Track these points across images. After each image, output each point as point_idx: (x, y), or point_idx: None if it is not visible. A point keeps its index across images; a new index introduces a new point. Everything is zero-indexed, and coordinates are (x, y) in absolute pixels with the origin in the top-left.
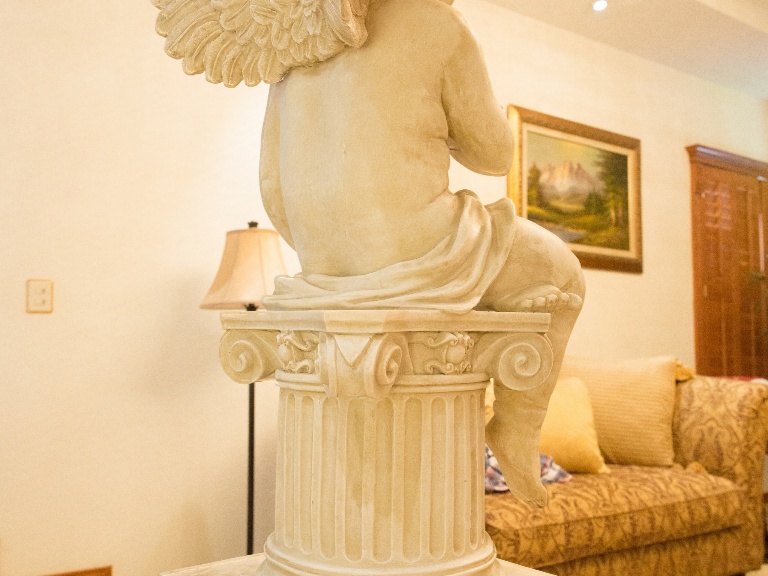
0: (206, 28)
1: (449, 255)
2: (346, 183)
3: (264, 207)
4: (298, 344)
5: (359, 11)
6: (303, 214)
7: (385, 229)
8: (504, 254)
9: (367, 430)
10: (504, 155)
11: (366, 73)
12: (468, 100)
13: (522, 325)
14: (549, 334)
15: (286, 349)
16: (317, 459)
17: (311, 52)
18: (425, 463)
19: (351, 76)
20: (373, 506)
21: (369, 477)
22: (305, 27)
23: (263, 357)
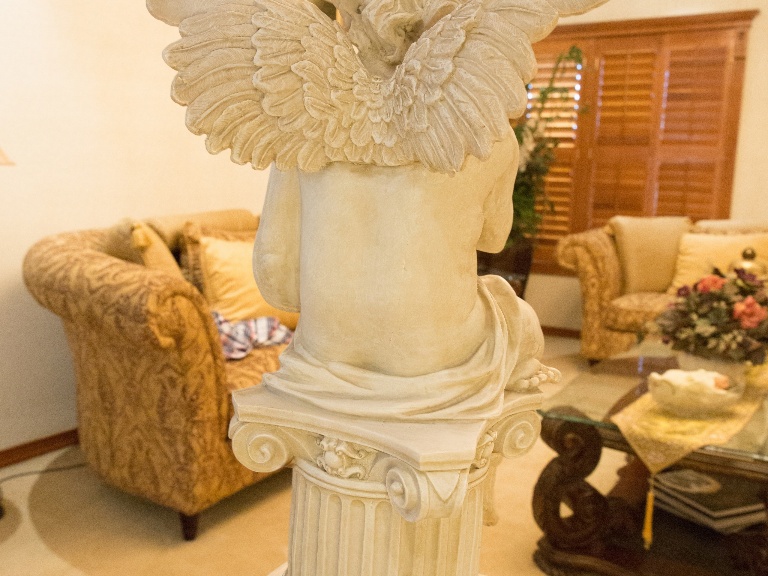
0: (242, 107)
1: (492, 366)
2: (403, 298)
3: (258, 275)
4: (352, 454)
5: None
6: (339, 313)
7: (435, 341)
8: (519, 349)
9: (419, 529)
10: None
11: (433, 192)
12: (501, 206)
13: (524, 407)
14: None
15: (338, 458)
16: (368, 557)
17: (371, 157)
18: (462, 547)
19: (417, 192)
20: None
21: (419, 569)
22: (369, 132)
23: (287, 449)
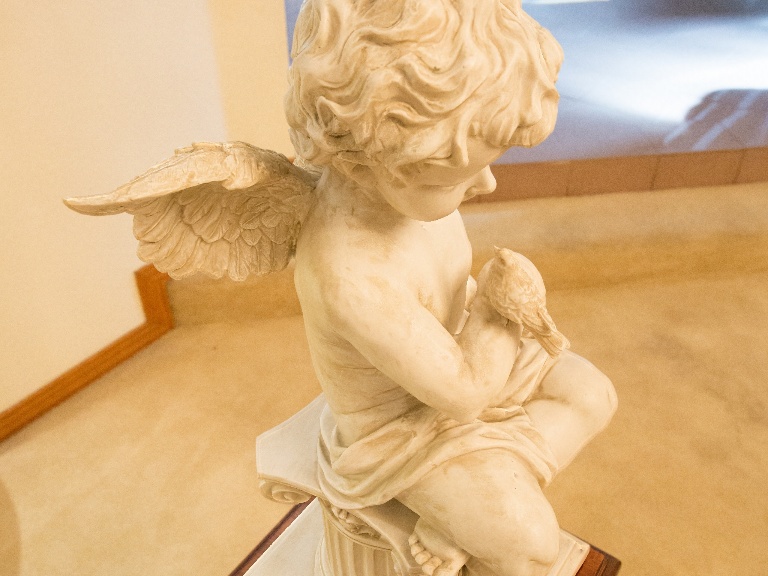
0: None
1: None
2: None
3: None
4: None
5: (281, 239)
6: None
7: None
8: (382, 497)
9: None
10: (442, 412)
11: None
12: None
13: None
14: (471, 572)
15: None
16: None
17: None
18: None
19: None
20: (325, 540)
21: None
22: None
23: None
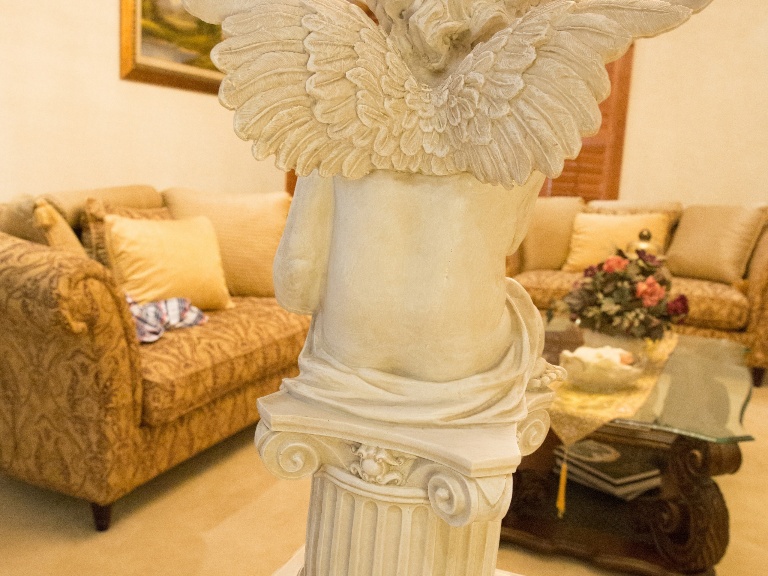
0: (293, 113)
1: (521, 370)
2: (444, 306)
3: (282, 280)
4: (391, 462)
5: None
6: (375, 320)
7: (470, 347)
8: (537, 351)
9: (453, 531)
10: None
11: (478, 202)
12: (528, 212)
13: (538, 406)
14: None
15: (377, 466)
16: (404, 560)
17: (418, 166)
18: (488, 545)
19: (463, 202)
20: None
21: (452, 569)
22: (419, 141)
23: (319, 457)
